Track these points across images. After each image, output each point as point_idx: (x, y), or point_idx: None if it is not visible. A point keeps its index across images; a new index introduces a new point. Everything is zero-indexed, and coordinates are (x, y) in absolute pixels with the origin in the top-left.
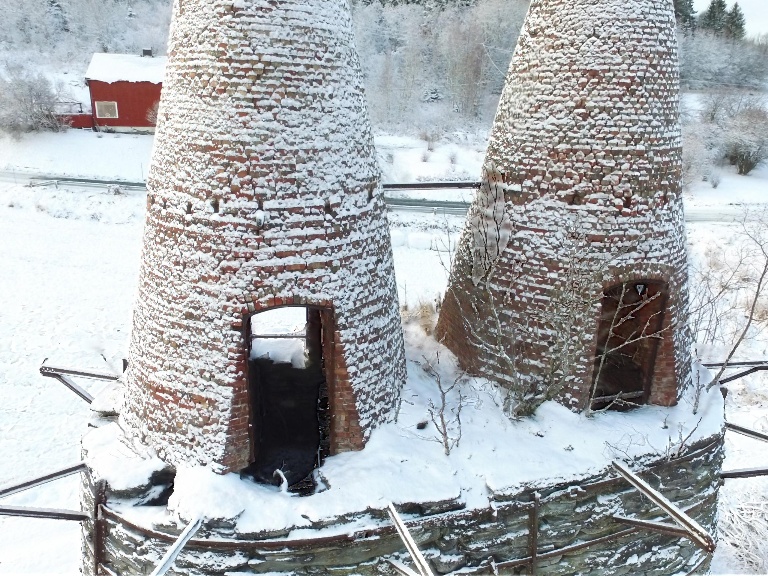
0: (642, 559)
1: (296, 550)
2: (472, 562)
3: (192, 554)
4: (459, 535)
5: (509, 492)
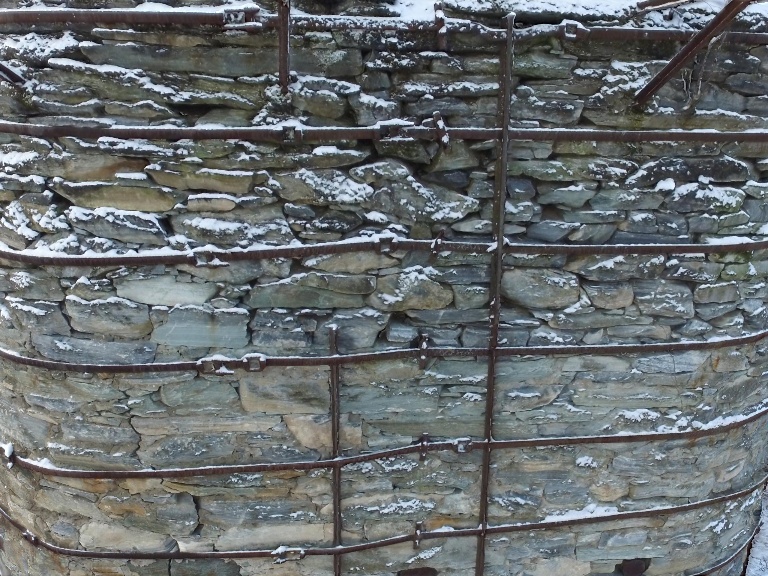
0: (681, 190)
1: (143, 32)
2: (409, 117)
3: (12, 37)
4: (389, 64)
5: (467, 4)
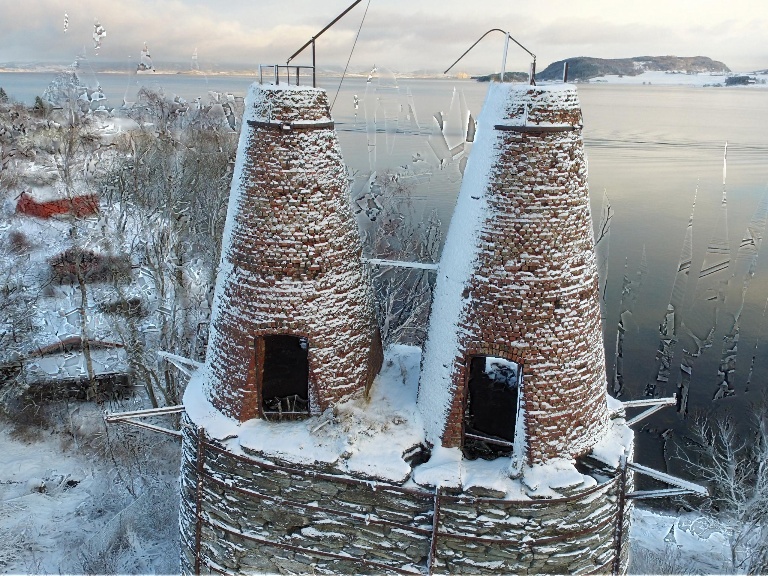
0: None
1: None
2: None
3: None
4: None
5: None
